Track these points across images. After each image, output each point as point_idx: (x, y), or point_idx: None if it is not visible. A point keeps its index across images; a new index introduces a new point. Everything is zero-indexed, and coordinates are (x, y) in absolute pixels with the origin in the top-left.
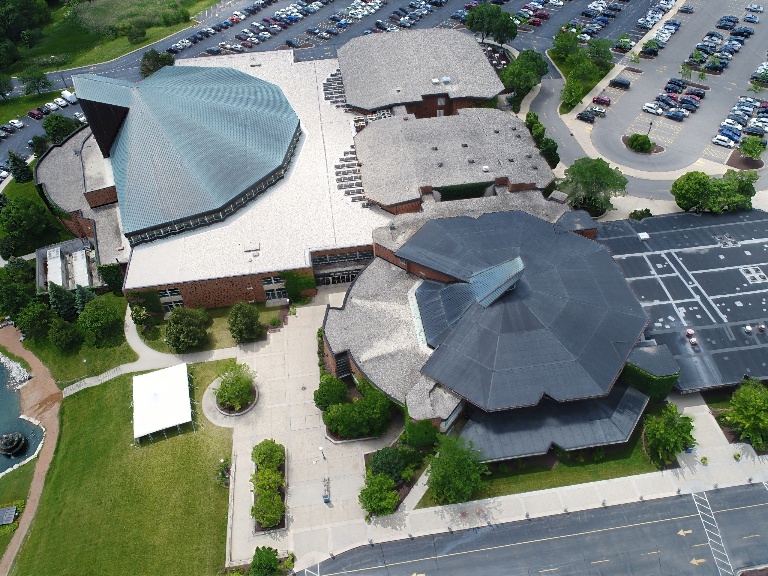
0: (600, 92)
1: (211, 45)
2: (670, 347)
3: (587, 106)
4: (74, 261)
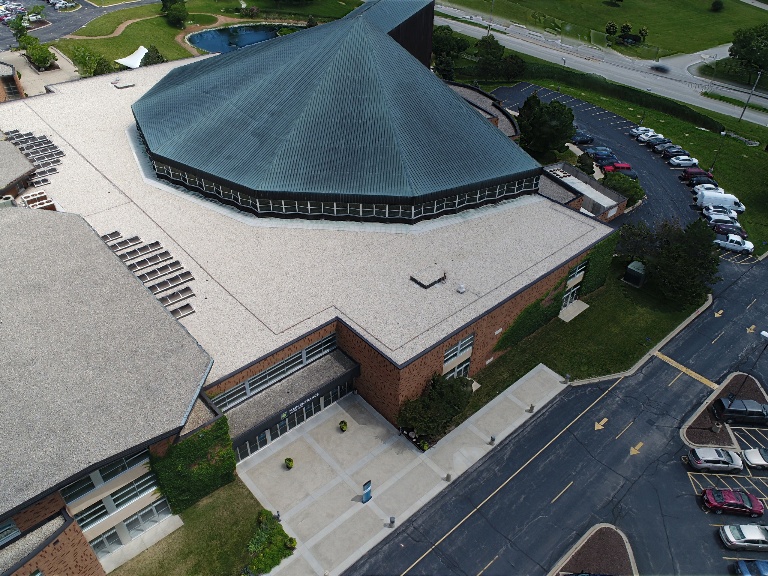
0: None
1: None
2: None
3: None
4: None
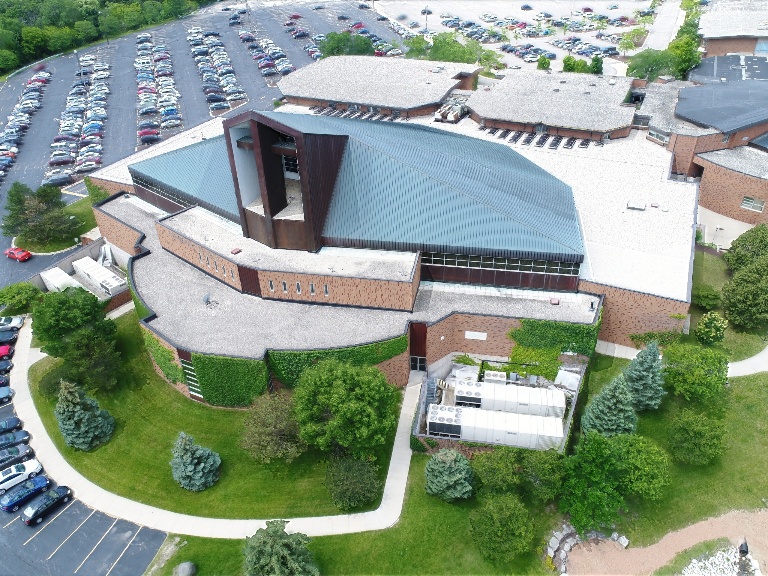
0: None
1: (31, 182)
2: None
3: None
4: (482, 396)
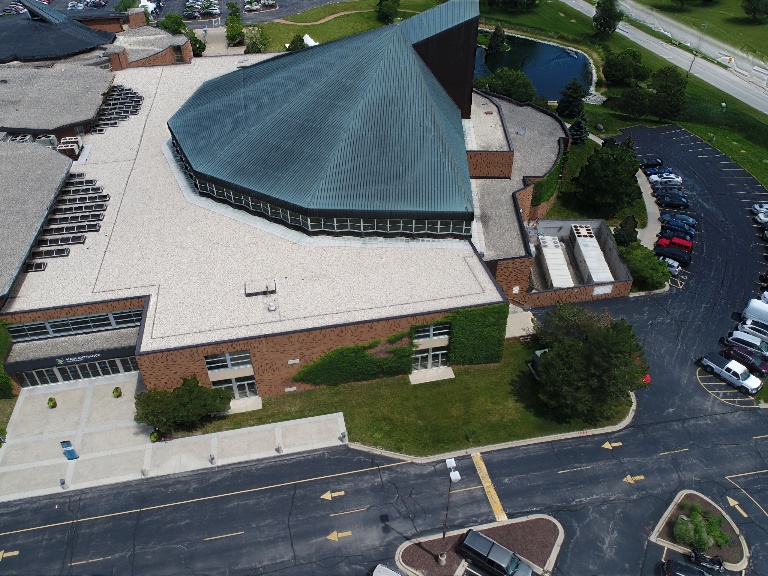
0: None
1: None
2: None
3: None
4: None
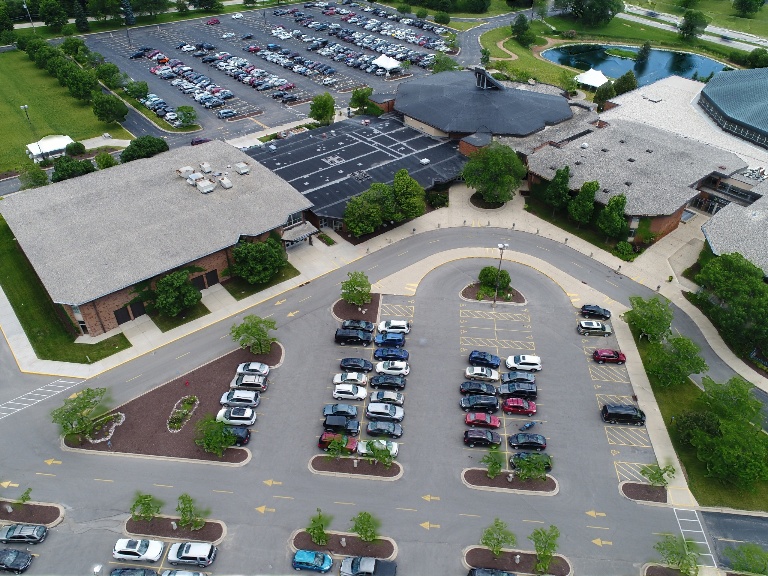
0: (634, 387)
1: None
2: (375, 120)
3: (619, 343)
4: None
